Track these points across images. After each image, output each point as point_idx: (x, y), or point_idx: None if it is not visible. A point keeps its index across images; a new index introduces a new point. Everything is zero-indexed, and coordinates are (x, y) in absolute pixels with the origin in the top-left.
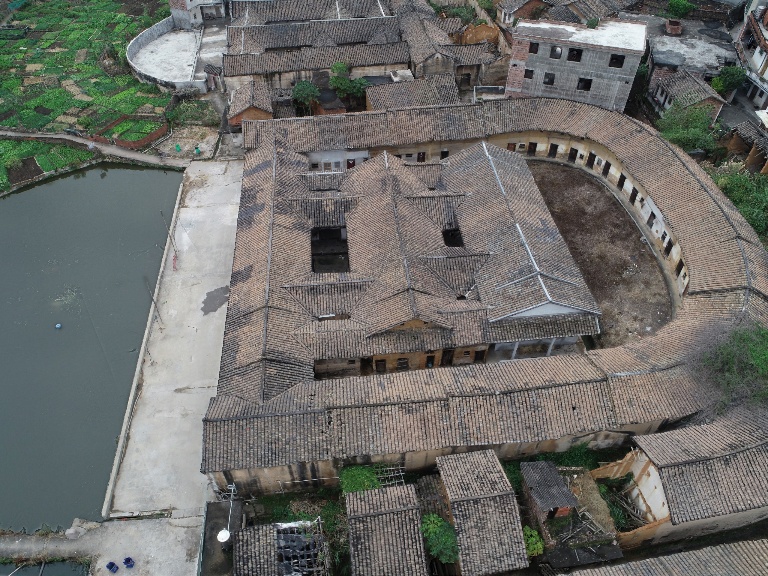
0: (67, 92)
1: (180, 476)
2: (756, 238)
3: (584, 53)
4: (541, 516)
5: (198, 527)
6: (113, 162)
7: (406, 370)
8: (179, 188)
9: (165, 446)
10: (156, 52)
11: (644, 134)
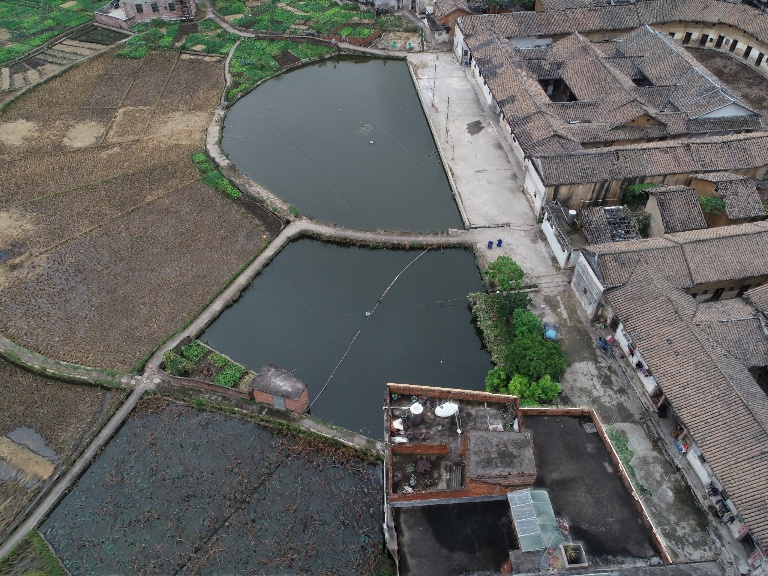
0: (286, 10)
1: (505, 209)
2: None
3: None
4: (765, 196)
5: (531, 230)
6: (347, 54)
7: None
8: (410, 68)
9: (486, 196)
10: None
11: (765, 16)
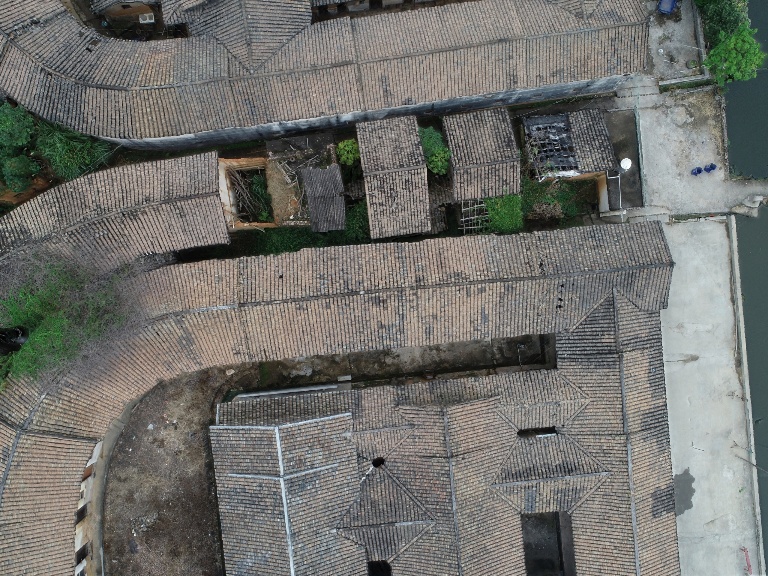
0: None
1: None
2: None
3: None
4: None
5: None
6: None
7: (444, 379)
8: None
9: (692, 290)
10: None
11: None
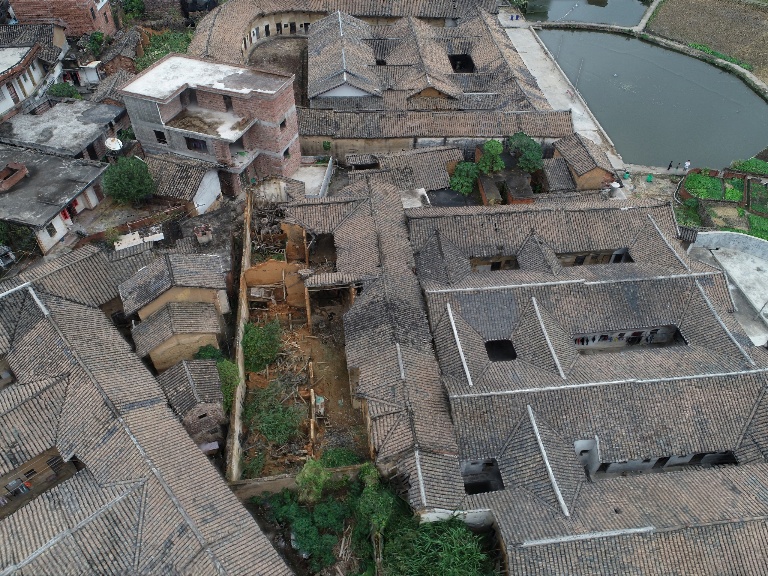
0: None
1: None
2: None
3: None
4: None
5: None
6: None
7: None
8: None
9: None
10: None
11: None
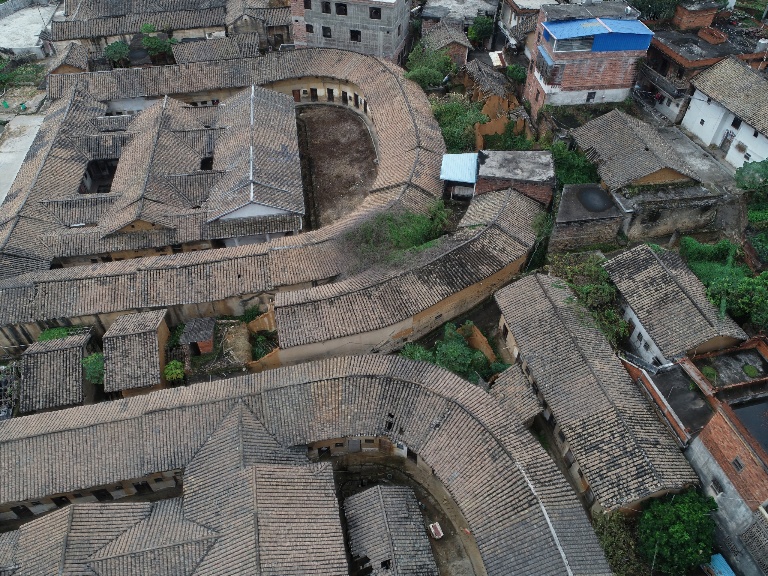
0: None
1: None
2: (442, 149)
3: (348, 7)
4: None
5: None
6: None
7: None
8: None
9: None
10: (9, 25)
11: (386, 73)
